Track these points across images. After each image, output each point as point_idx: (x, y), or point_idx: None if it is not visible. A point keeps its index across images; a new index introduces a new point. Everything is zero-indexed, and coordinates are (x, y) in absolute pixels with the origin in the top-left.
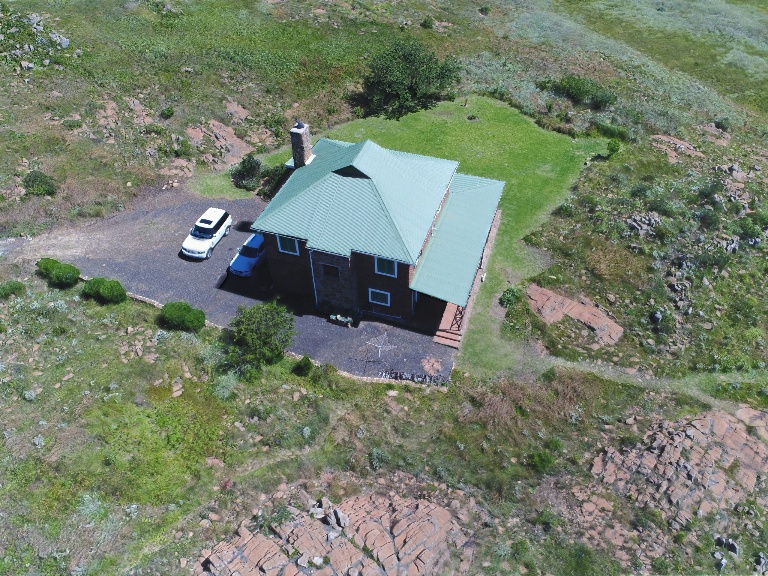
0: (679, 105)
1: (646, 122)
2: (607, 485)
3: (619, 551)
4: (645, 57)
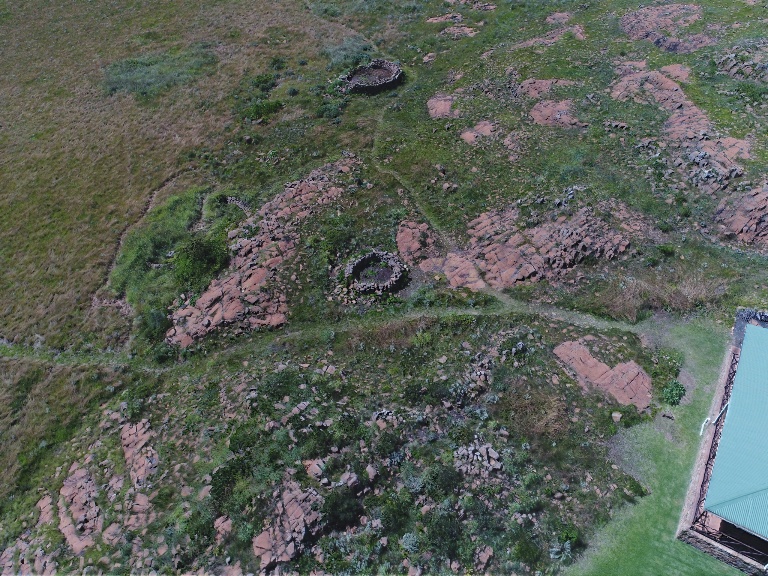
0: None
1: None
2: (621, 235)
3: (624, 209)
4: None
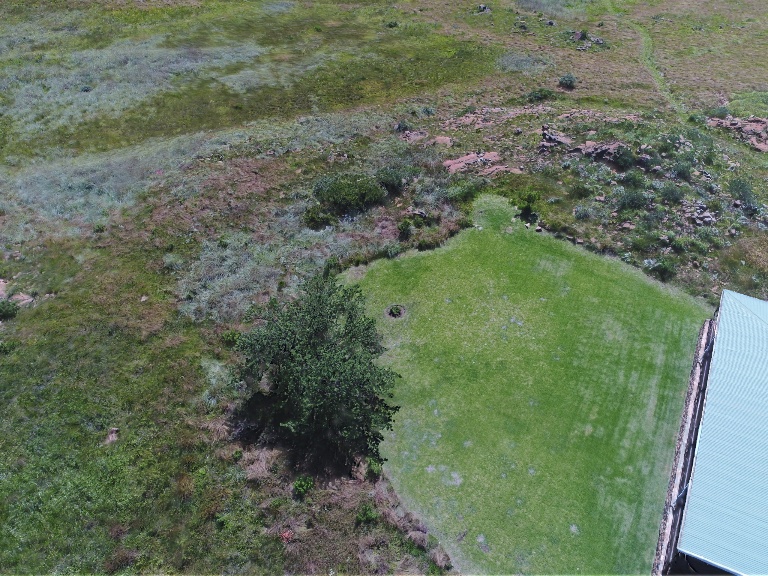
0: (351, 142)
1: (432, 166)
2: None
3: None
4: (216, 132)
